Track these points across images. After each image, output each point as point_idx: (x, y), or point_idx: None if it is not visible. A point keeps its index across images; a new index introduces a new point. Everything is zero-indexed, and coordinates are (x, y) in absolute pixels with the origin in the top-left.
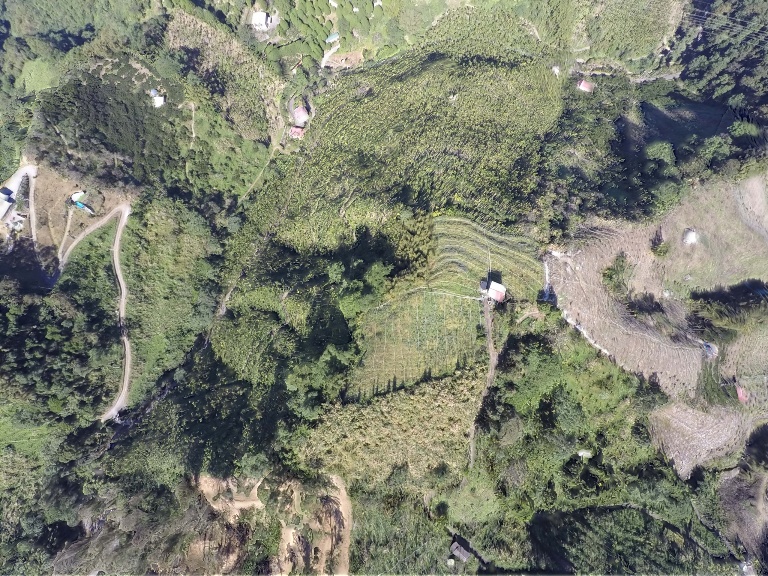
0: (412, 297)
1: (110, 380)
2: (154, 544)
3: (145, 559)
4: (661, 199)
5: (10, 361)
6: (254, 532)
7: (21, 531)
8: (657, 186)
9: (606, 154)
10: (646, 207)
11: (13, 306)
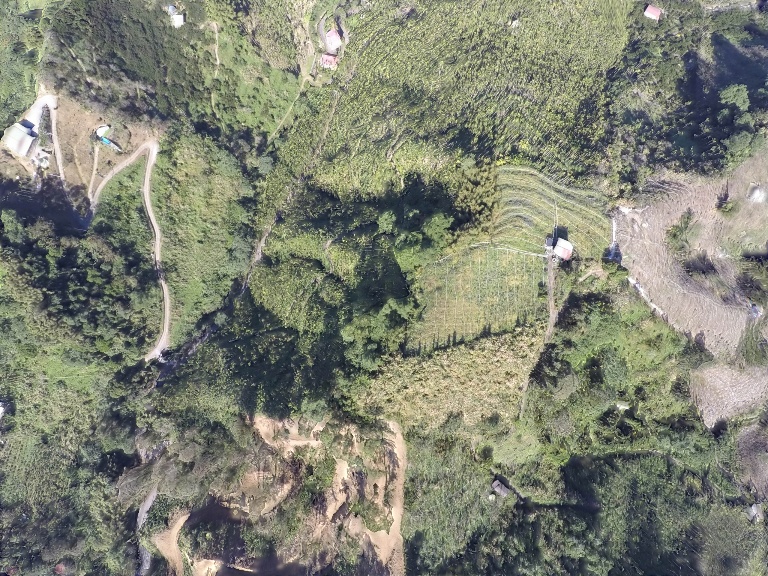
0: (474, 252)
1: (151, 322)
2: (214, 474)
3: (203, 485)
4: (729, 149)
5: (56, 303)
6: (316, 469)
7: (81, 457)
8: (725, 134)
9: (670, 95)
10: (714, 158)
11: (52, 248)
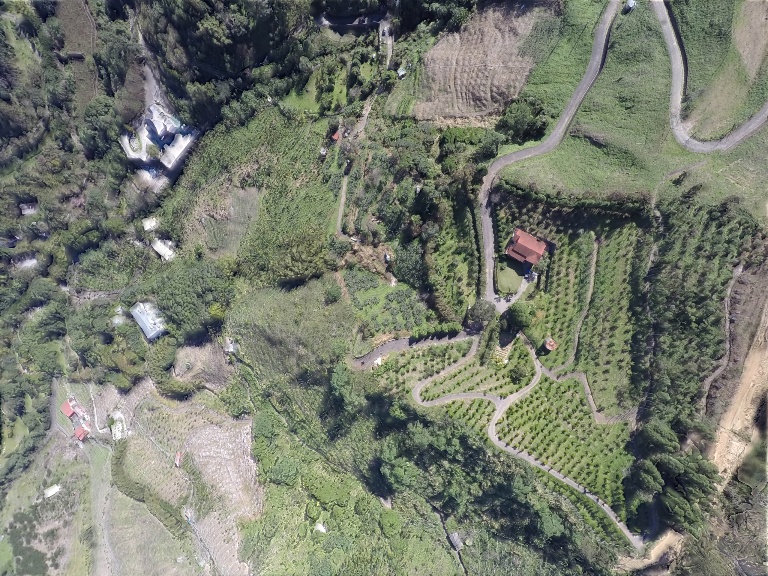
0: None
1: None
2: None
3: None
4: None
5: None
6: None
7: None
8: None
9: None
10: None
11: None
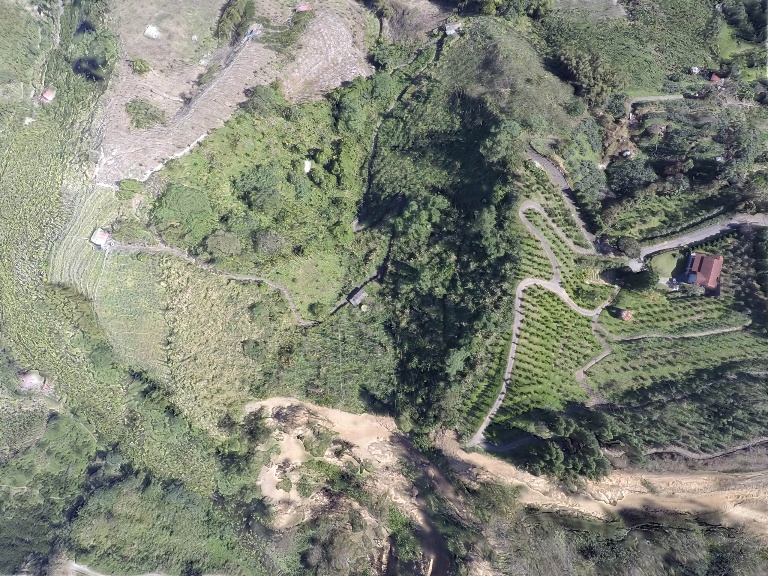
0: (98, 316)
1: None
2: None
3: None
4: (114, 53)
5: None
6: None
7: None
8: None
9: None
10: None
11: None
